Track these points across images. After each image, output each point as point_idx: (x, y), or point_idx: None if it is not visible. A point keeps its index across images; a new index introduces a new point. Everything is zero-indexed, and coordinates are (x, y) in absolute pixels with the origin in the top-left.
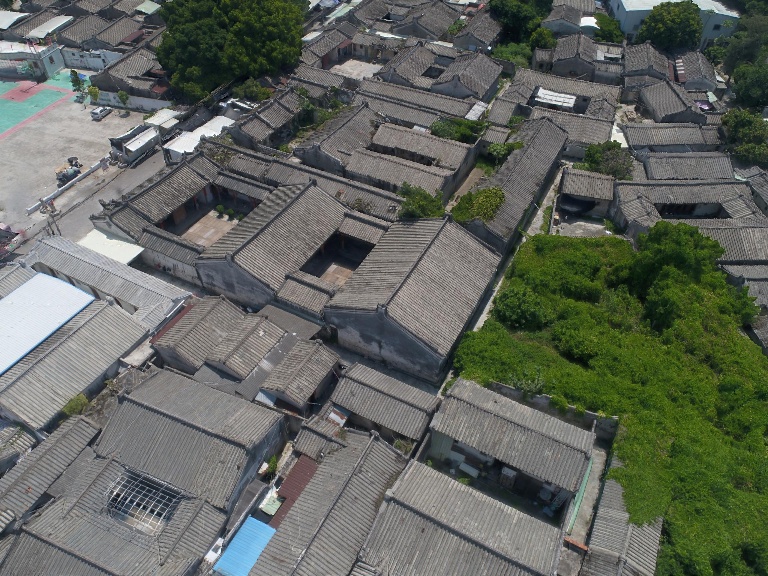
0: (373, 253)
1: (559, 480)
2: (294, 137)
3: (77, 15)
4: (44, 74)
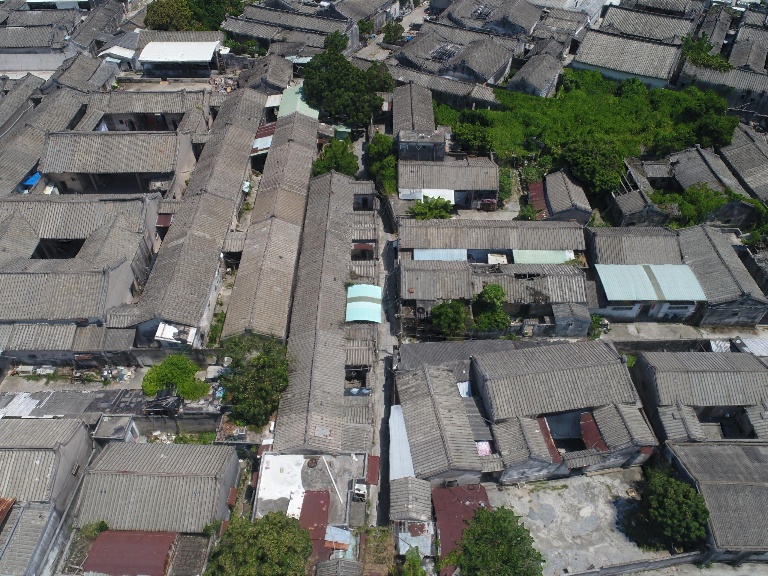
0: None
1: (512, 79)
2: None
3: None
4: None
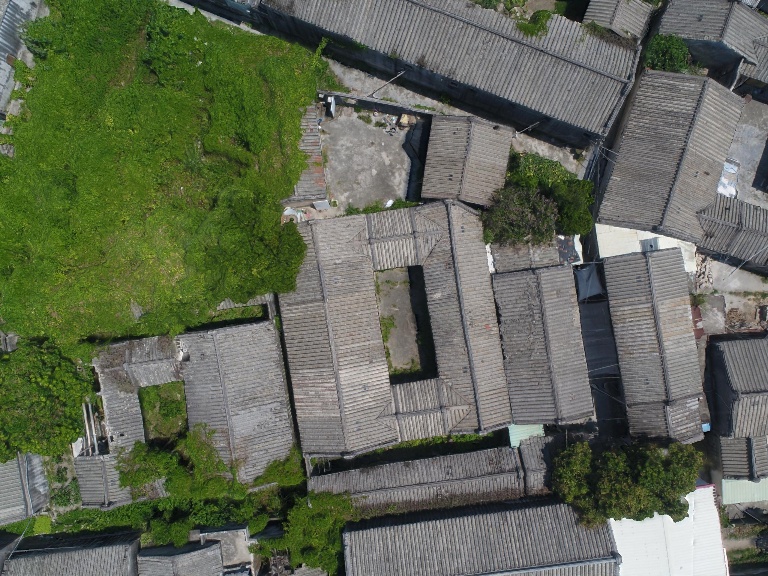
0: None
1: None
2: None
3: None
4: None
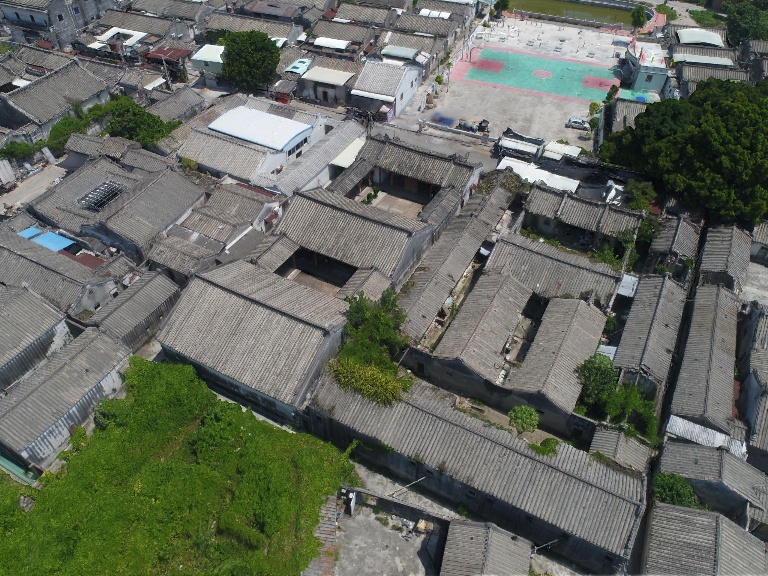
0: (309, 289)
1: None
2: (583, 251)
3: (756, 70)
4: (631, 84)
